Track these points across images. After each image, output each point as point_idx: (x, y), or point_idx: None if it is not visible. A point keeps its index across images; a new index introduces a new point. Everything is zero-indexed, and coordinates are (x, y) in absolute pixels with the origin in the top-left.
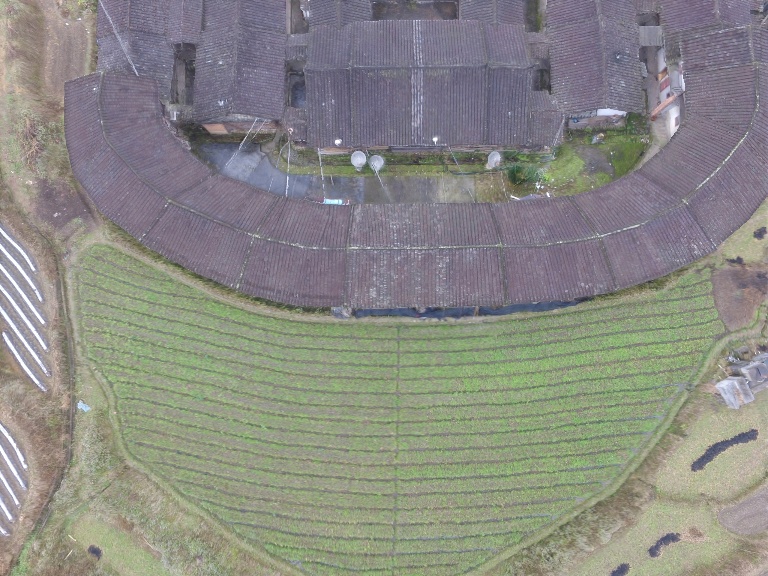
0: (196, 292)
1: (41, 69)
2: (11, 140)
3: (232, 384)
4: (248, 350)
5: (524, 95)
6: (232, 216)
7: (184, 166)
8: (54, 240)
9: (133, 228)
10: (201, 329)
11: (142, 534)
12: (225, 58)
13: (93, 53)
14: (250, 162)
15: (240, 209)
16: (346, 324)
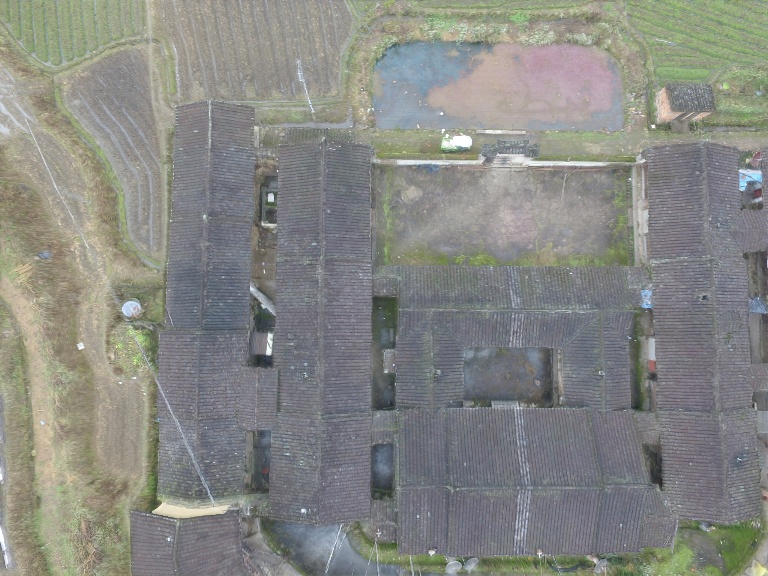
0: None
1: (92, 438)
2: (63, 541)
3: None
4: None
5: (638, 509)
6: None
7: None
8: None
9: None
10: None
11: None
12: (307, 458)
13: (151, 418)
14: (328, 545)
15: None
16: None
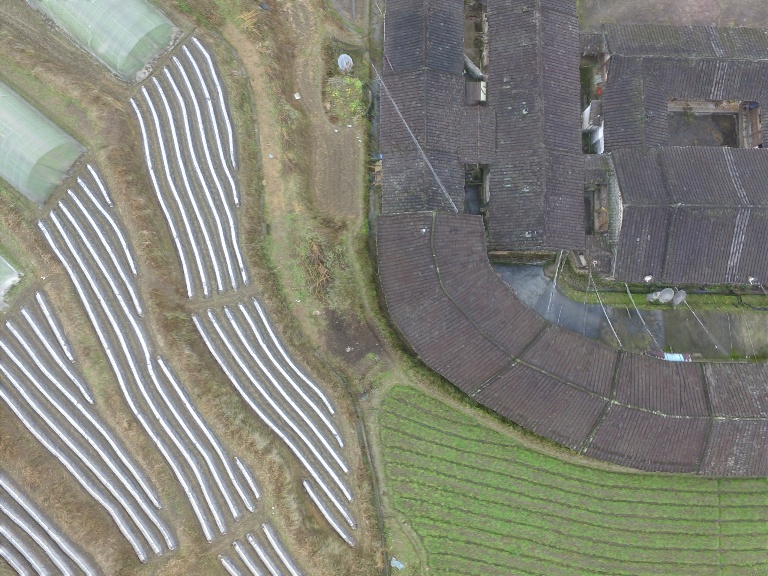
0: (507, 439)
1: (310, 180)
2: (294, 265)
3: (549, 539)
4: (564, 502)
5: None
6: (582, 377)
7: (519, 316)
8: (349, 378)
9: (463, 381)
10: (514, 479)
11: None
12: (531, 185)
13: (366, 164)
14: (535, 288)
15: (587, 368)
16: (664, 475)
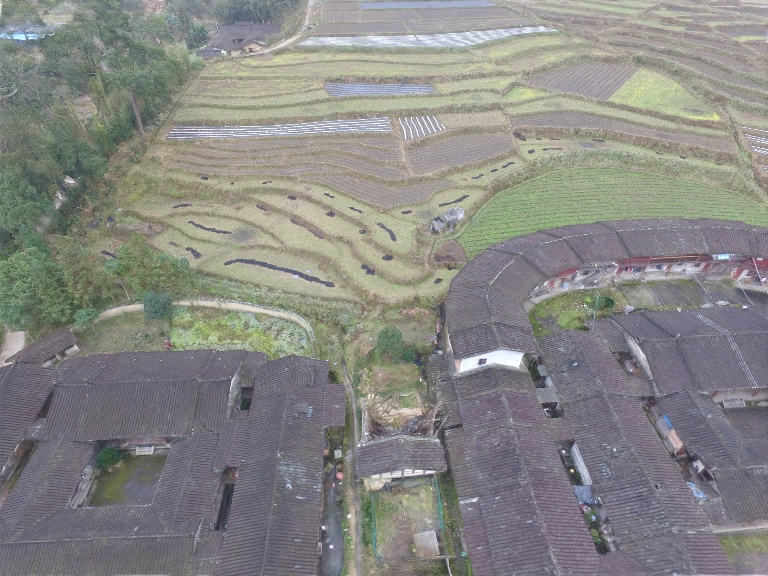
0: None
1: None
2: None
3: (706, 212)
4: None
5: None
6: None
7: None
8: None
9: None
10: None
11: (705, 167)
12: None
13: None
14: None
15: None
16: None
